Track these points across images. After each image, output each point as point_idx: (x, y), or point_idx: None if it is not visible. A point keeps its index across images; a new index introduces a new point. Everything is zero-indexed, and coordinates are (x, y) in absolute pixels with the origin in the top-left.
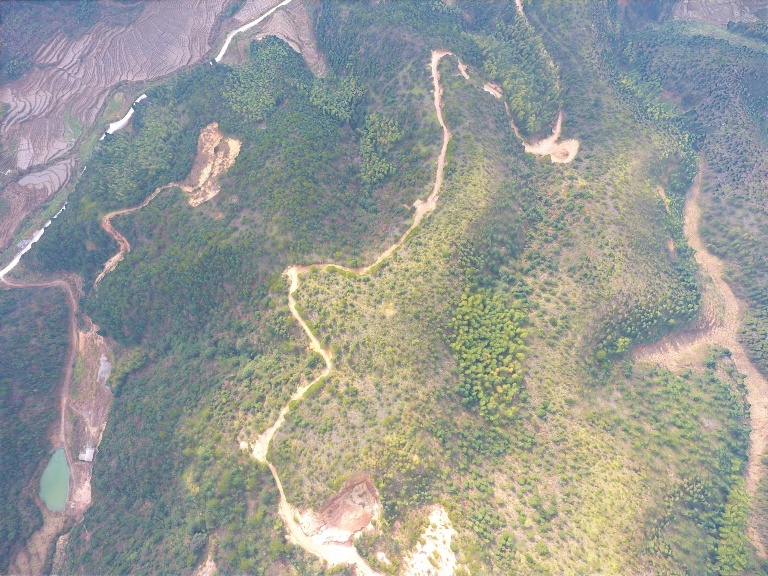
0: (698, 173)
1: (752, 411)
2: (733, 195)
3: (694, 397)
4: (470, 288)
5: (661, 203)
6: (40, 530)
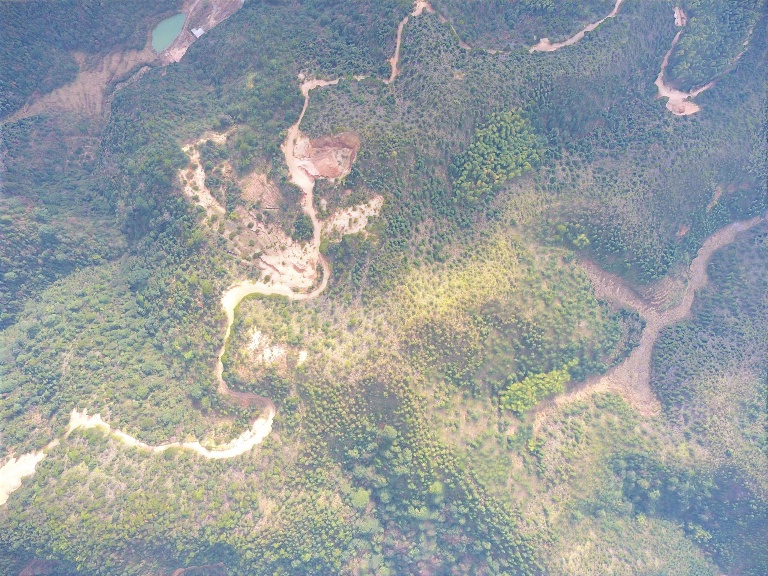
0: (761, 218)
1: (620, 370)
2: (766, 247)
3: (592, 311)
4: (522, 114)
5: (708, 195)
6: (139, 51)
